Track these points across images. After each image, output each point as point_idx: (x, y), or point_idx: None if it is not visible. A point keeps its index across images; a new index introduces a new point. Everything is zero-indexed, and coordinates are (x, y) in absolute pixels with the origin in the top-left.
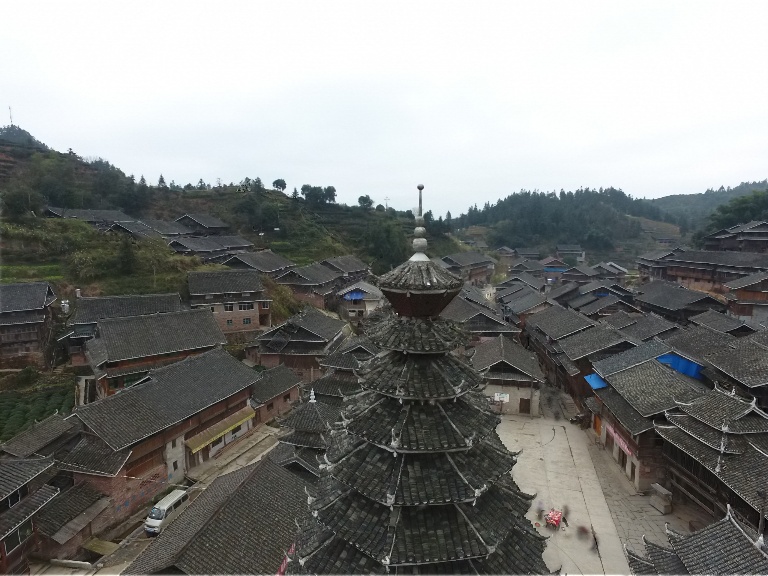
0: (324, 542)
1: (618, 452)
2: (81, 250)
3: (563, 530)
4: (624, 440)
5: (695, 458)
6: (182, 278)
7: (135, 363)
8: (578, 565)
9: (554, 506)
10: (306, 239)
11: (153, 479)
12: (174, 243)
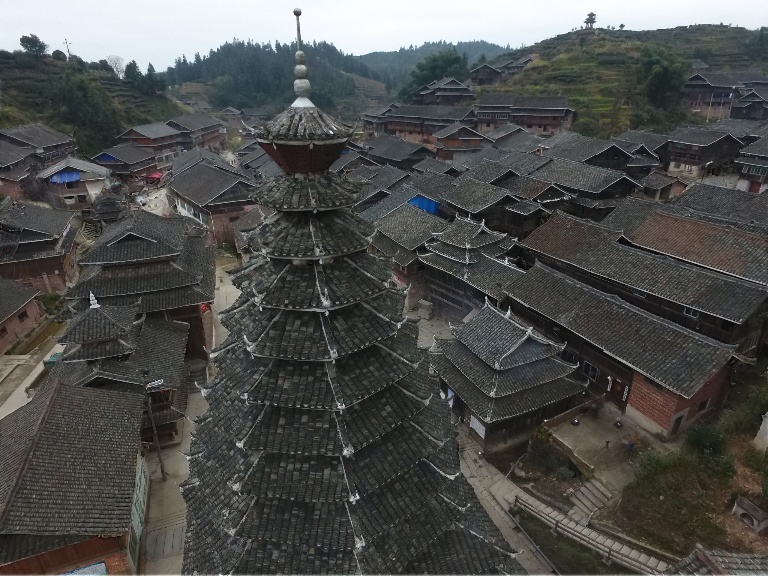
0: (256, 419)
1: None
2: None
3: None
4: (394, 273)
5: (450, 273)
6: None
7: None
8: None
9: None
10: None
11: None
12: None
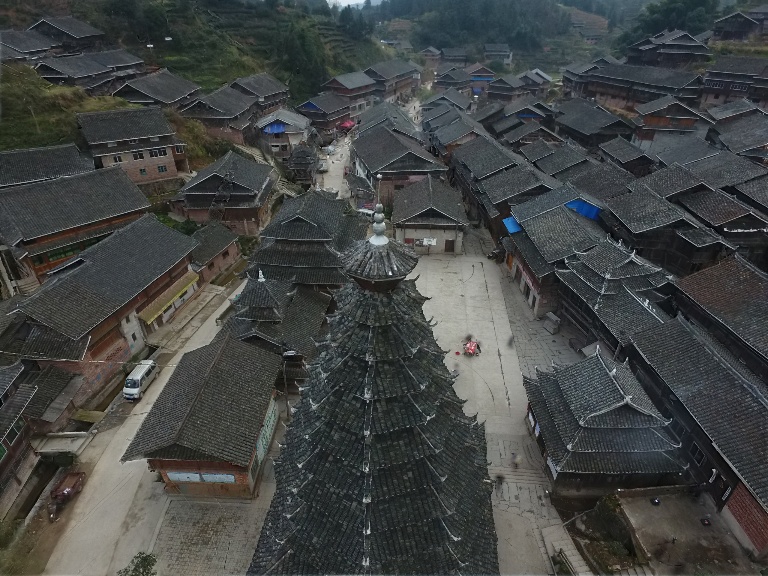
0: (314, 451)
1: (524, 286)
2: None
3: (477, 356)
4: (530, 278)
5: (582, 297)
6: (70, 119)
7: (55, 237)
8: (486, 381)
9: (471, 336)
10: (207, 52)
11: (117, 353)
12: (42, 67)
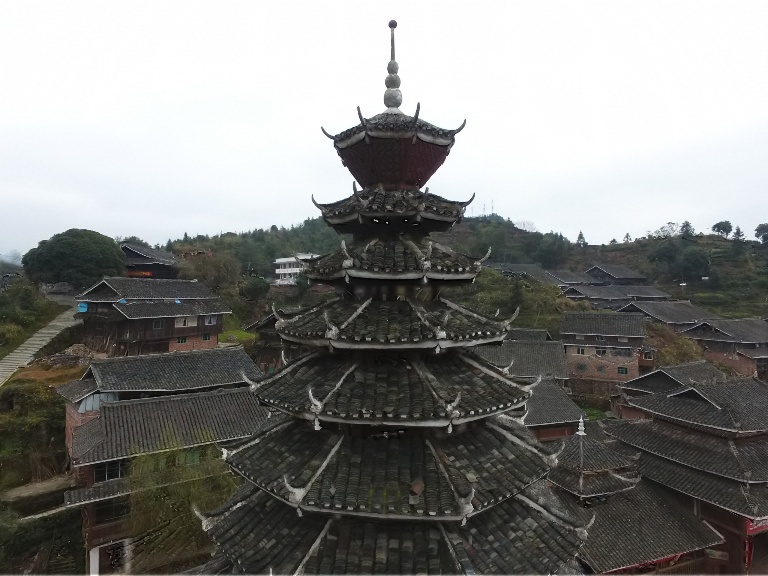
0: None
1: None
2: (485, 291)
3: None
4: None
5: None
6: None
7: None
8: None
9: None
10: (751, 290)
11: None
12: (571, 290)
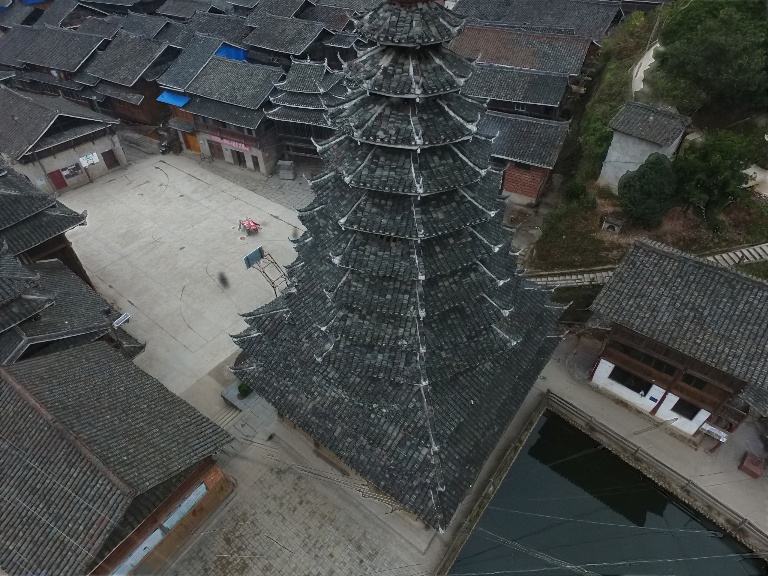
0: (421, 254)
1: (231, 155)
2: None
3: (261, 229)
4: (237, 141)
5: (309, 123)
6: None
7: None
8: None
9: (235, 220)
10: None
11: None
12: None
